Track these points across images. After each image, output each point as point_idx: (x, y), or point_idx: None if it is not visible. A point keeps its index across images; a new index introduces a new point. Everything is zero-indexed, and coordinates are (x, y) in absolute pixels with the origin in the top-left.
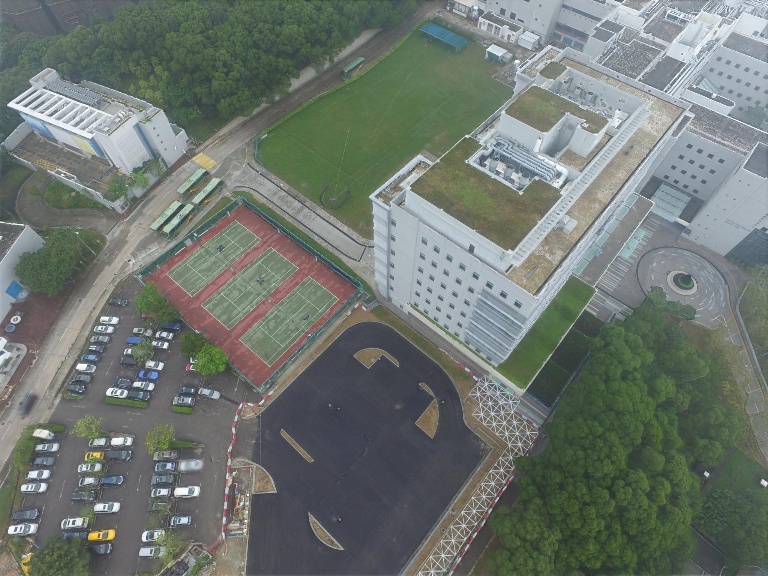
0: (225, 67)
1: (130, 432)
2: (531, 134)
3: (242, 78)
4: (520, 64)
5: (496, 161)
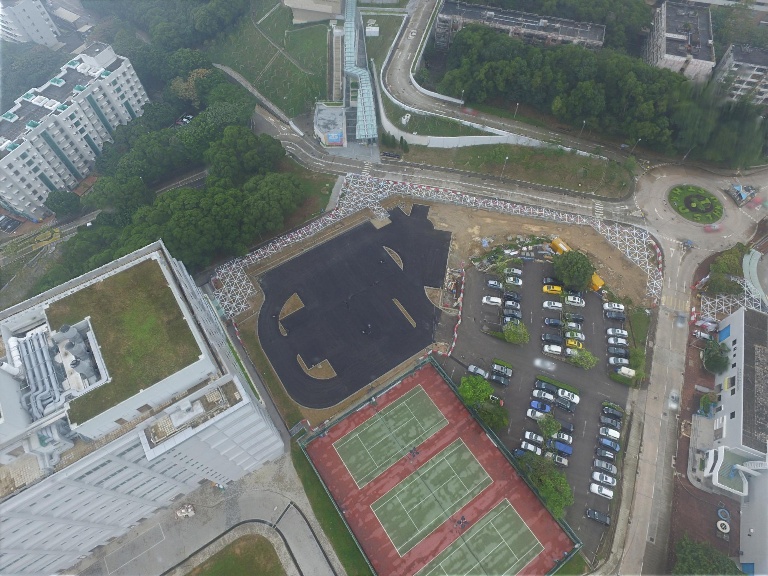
0: None
1: (548, 357)
2: (2, 381)
3: None
4: None
5: (78, 359)
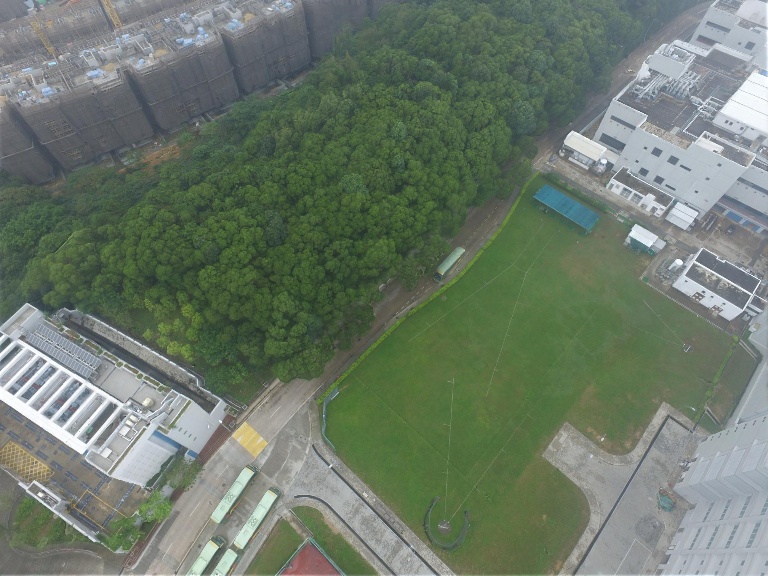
0: (286, 317)
1: None
2: None
3: (309, 330)
4: (676, 257)
5: None
